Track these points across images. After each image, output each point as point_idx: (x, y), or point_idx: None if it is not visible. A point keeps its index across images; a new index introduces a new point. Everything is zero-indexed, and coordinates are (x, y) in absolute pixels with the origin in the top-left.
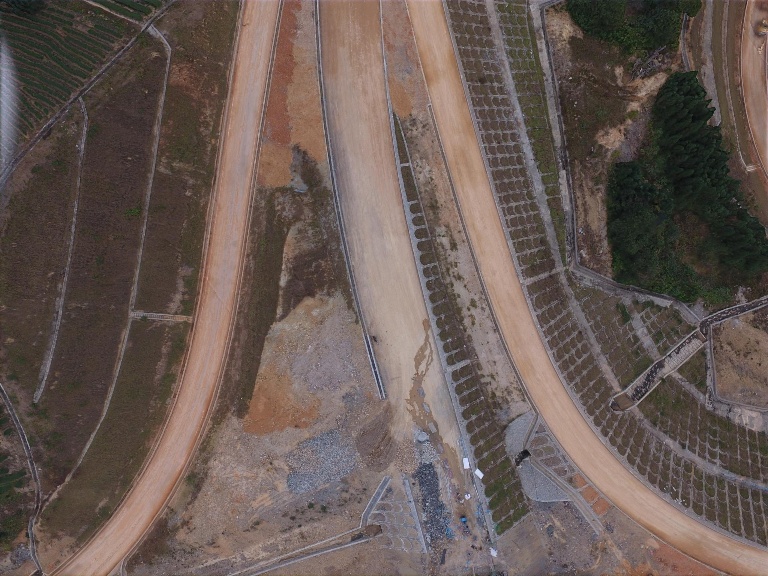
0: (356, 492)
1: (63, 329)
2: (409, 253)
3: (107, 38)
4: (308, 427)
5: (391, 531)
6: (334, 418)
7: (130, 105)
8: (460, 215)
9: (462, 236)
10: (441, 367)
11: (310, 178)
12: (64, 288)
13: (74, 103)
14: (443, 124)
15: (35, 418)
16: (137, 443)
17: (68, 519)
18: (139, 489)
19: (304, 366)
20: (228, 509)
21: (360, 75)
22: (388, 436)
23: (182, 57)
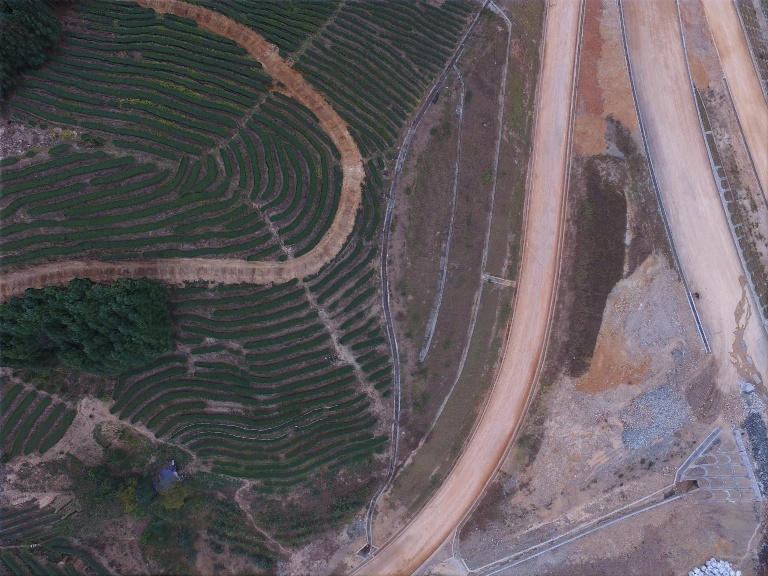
0: (685, 446)
1: (447, 288)
2: (720, 214)
3: (460, 13)
4: (640, 383)
5: (712, 484)
6: (665, 373)
7: (486, 75)
8: (757, 179)
9: (760, 198)
10: (760, 320)
11: (625, 146)
12: (448, 247)
13: (450, 71)
14: (736, 95)
15: (415, 378)
16: (469, 408)
17: (409, 487)
18: (468, 455)
19: (636, 323)
20: (566, 468)
21: (661, 51)
22: (715, 389)
23: (516, 32)
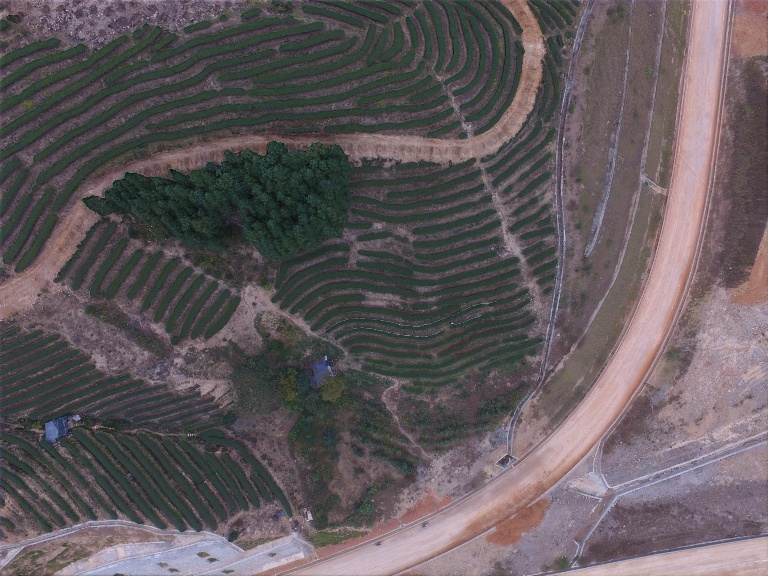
0: None
1: (615, 180)
2: None
3: None
4: None
5: None
6: None
7: None
8: None
9: None
10: None
11: None
12: (617, 138)
13: None
14: None
15: (578, 275)
16: (616, 318)
17: (555, 396)
18: (612, 368)
19: None
20: (719, 382)
21: None
22: None
23: None
